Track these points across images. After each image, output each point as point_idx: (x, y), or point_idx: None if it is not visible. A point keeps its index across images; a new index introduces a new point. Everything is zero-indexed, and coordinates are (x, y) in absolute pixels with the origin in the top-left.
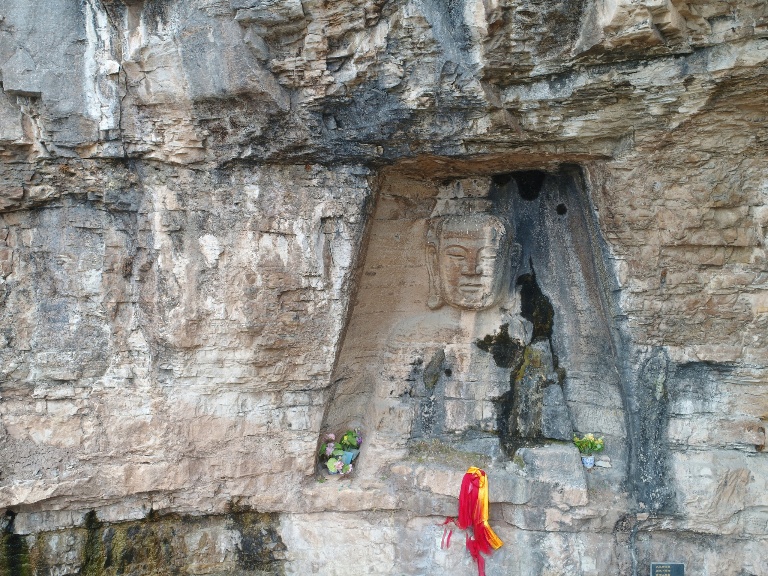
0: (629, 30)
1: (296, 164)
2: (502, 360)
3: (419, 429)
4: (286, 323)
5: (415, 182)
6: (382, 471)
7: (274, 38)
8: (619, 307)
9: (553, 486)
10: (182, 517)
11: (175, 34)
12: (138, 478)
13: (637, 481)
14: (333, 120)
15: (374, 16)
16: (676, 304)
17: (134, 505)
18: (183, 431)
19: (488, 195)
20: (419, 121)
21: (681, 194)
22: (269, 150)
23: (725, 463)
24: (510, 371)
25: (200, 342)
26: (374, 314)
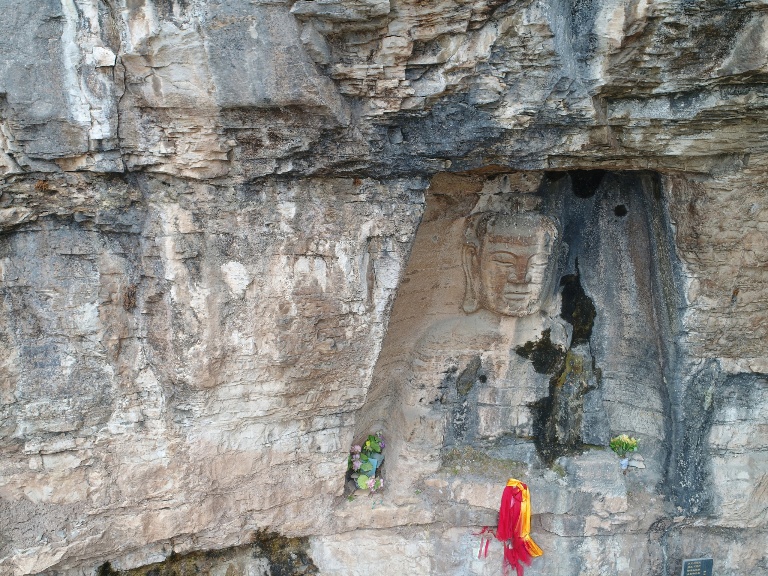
0: None
1: (342, 177)
2: (542, 366)
3: (451, 437)
4: (323, 352)
5: (459, 178)
6: (415, 485)
7: (339, 36)
8: (682, 323)
9: (595, 495)
10: (205, 553)
11: (200, 23)
12: (158, 526)
13: (676, 486)
14: (400, 133)
15: (482, 19)
16: (741, 321)
17: (153, 550)
18: (205, 470)
19: (537, 190)
20: (506, 138)
21: None
22: (314, 165)
23: (762, 466)
24: (550, 377)
25: (224, 379)
26: (404, 320)
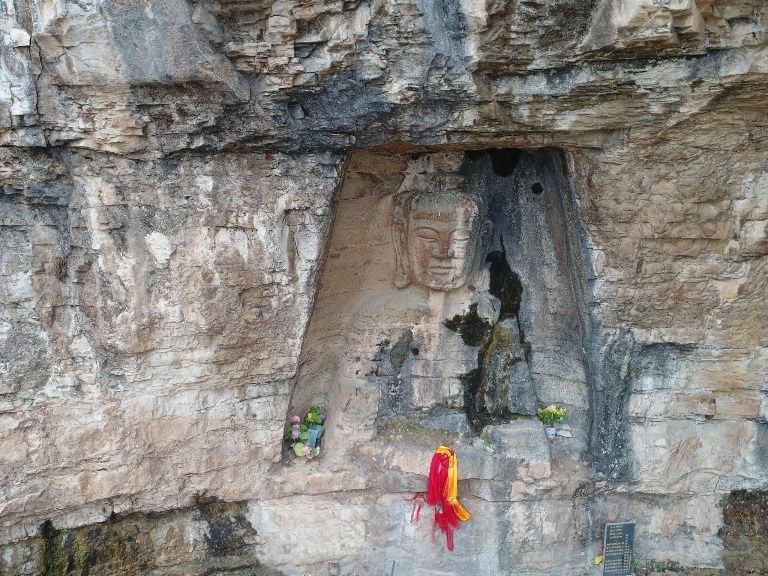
0: (646, 32)
1: (255, 152)
2: (470, 339)
3: (386, 407)
4: (249, 321)
5: (382, 157)
6: (350, 452)
7: (229, 16)
8: (593, 294)
9: (519, 462)
10: (146, 514)
11: (102, 5)
12: (96, 486)
13: (597, 453)
14: (300, 109)
15: None
16: (648, 292)
17: (93, 510)
18: (141, 434)
19: (460, 170)
20: (399, 113)
21: (667, 189)
22: (224, 140)
23: (678, 433)
24: (478, 350)
25: (154, 345)
26: (338, 295)
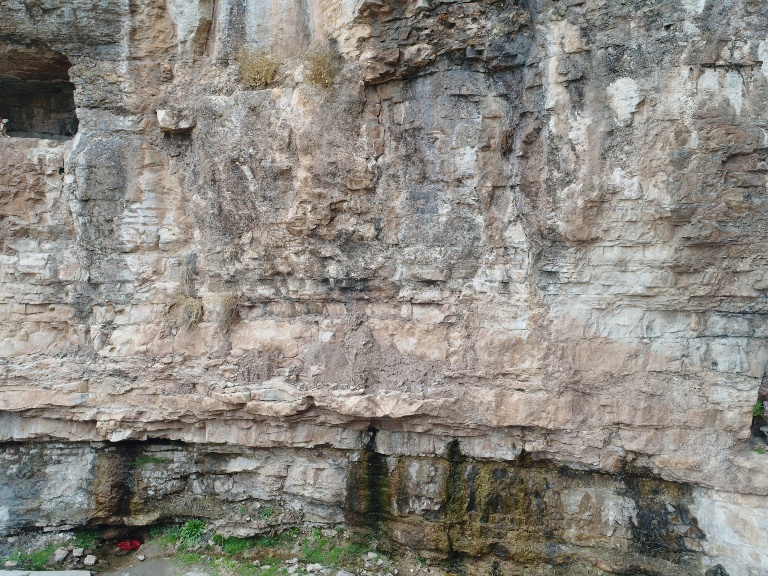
0: None
1: None
2: None
3: None
4: (731, 204)
5: None
6: None
7: None
8: None
9: None
10: (558, 468)
11: None
12: (511, 407)
13: None
14: None
15: None
16: None
17: (502, 442)
18: (567, 355)
19: None
20: None
21: None
22: None
23: None
24: None
25: (599, 234)
26: None
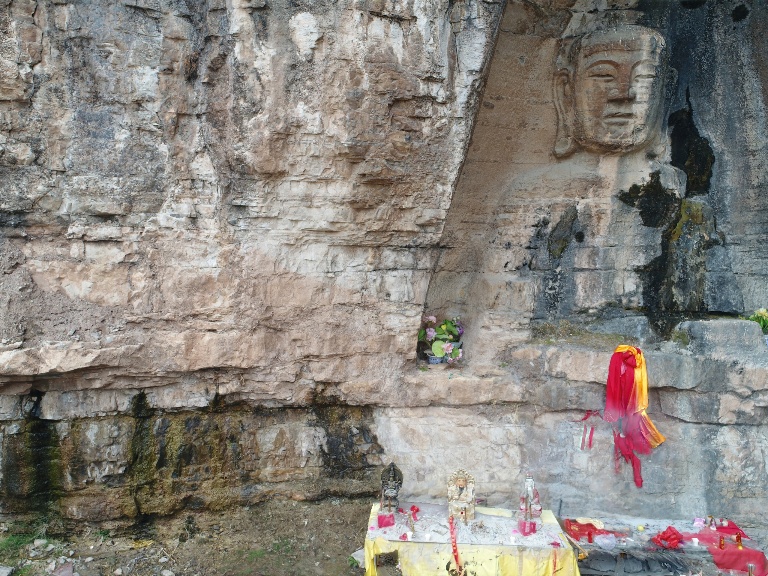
0: None
1: None
2: (651, 217)
3: (542, 308)
4: (396, 145)
5: None
6: (501, 356)
7: None
8: None
9: (730, 365)
10: (253, 408)
11: None
12: (202, 349)
13: None
14: None
15: None
16: None
17: (194, 388)
18: (258, 292)
19: (638, 5)
20: None
21: None
22: None
23: None
24: (662, 230)
25: (285, 167)
26: (487, 164)
